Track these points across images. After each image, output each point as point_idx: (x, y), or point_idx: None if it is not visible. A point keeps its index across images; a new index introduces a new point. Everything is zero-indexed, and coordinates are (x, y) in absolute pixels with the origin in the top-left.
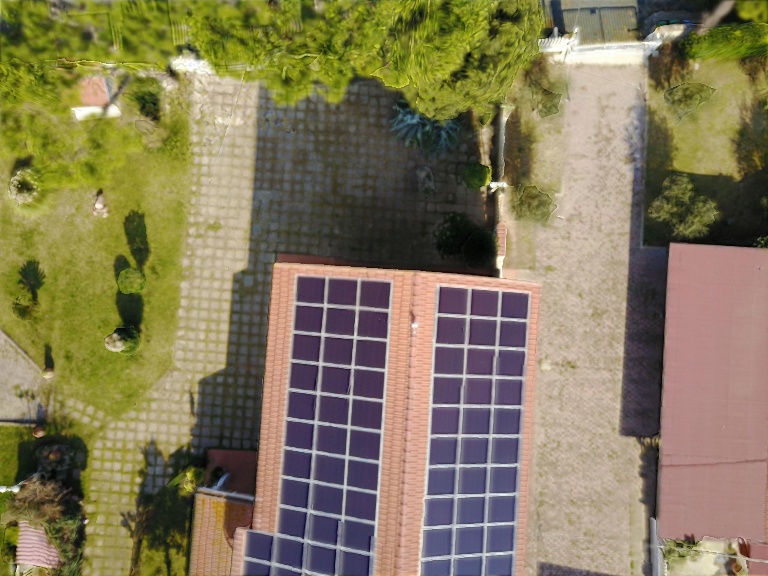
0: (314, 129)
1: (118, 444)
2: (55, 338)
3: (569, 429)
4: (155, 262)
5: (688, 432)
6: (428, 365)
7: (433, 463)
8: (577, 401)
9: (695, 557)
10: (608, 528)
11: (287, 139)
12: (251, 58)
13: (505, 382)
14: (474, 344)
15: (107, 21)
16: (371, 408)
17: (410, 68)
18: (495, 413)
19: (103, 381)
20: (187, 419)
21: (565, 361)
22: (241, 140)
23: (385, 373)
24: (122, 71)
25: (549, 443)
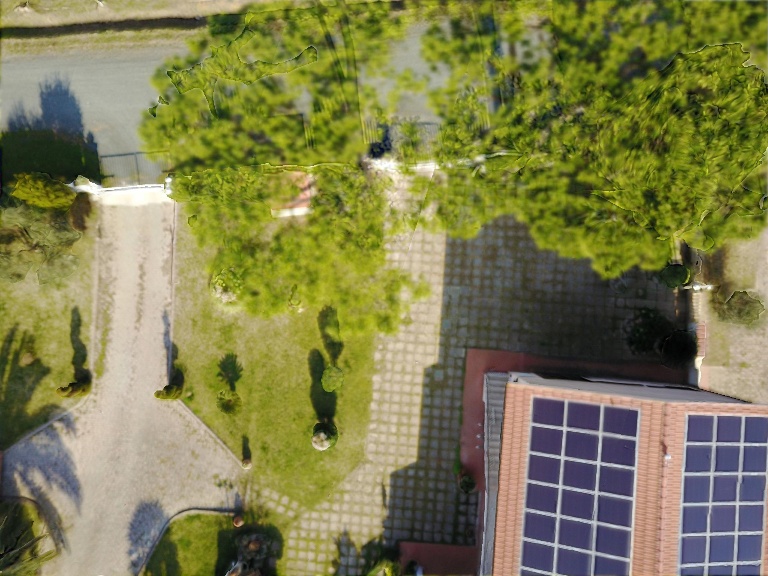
0: (502, 225)
1: (312, 534)
2: (252, 429)
3: None
4: (347, 356)
5: None
6: (677, 494)
7: None
8: None
9: None
10: None
11: (476, 235)
12: (440, 156)
13: (748, 508)
14: (719, 471)
15: (301, 122)
16: (618, 535)
17: (621, 177)
18: (739, 540)
19: (298, 472)
20: (379, 511)
21: None
22: (430, 236)
23: (633, 501)
24: (323, 174)
25: None
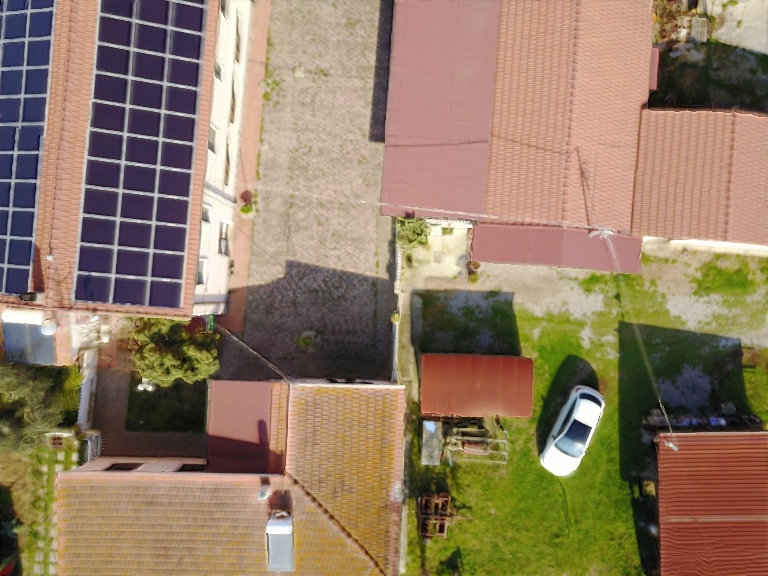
0: None
1: None
2: None
3: (321, 135)
4: None
5: (413, 115)
6: None
7: (101, 70)
8: (329, 108)
9: (439, 259)
10: (355, 229)
11: None
12: None
13: (183, 7)
14: None
15: None
16: (44, 18)
17: None
18: (171, 34)
19: None
20: None
21: (318, 69)
22: None
23: None
24: None
25: (301, 148)
